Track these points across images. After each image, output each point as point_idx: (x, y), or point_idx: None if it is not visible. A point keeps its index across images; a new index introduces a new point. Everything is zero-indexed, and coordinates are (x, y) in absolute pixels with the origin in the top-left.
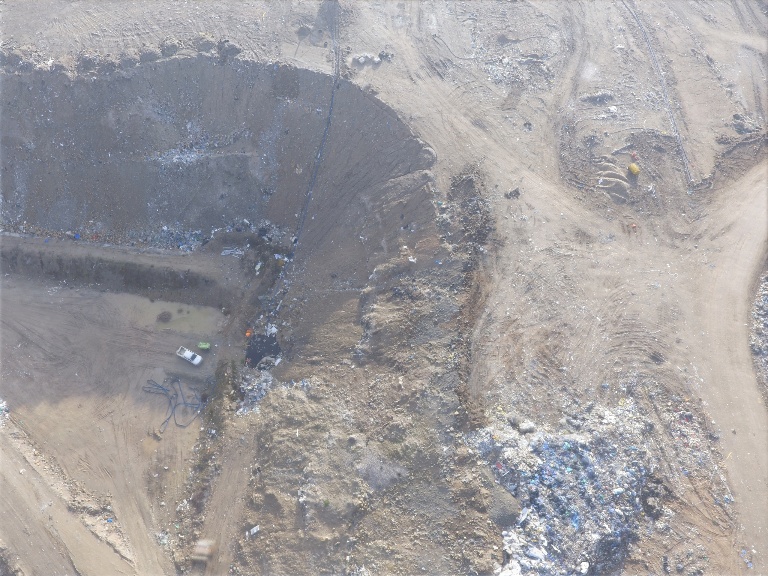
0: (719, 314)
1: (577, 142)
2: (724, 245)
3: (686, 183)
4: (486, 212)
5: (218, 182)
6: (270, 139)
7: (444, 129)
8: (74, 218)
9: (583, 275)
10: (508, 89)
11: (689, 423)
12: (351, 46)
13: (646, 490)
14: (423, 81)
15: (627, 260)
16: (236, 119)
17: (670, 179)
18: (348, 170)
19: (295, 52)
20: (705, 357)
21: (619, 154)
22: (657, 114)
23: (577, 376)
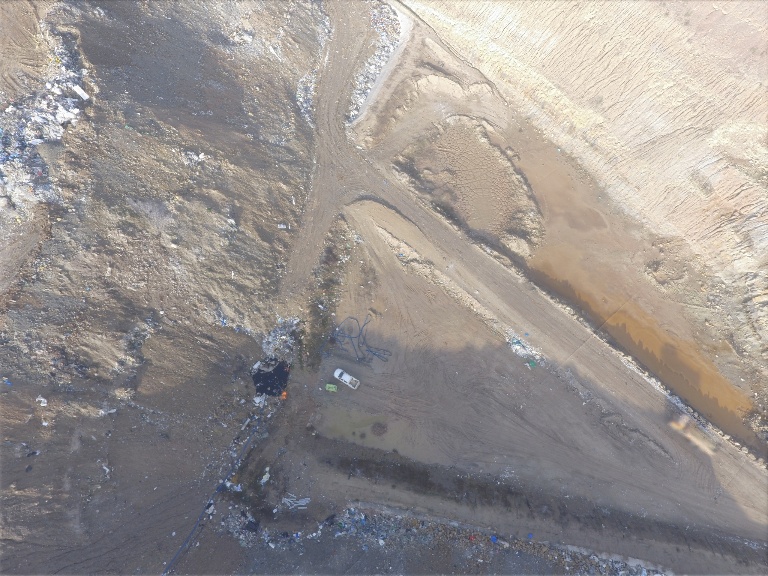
0: None
1: None
2: None
3: None
4: None
5: None
6: None
7: None
8: (503, 567)
9: None
10: None
11: None
12: None
13: None
14: None
15: None
16: None
17: None
18: None
19: None
20: None
21: None
22: None
23: None
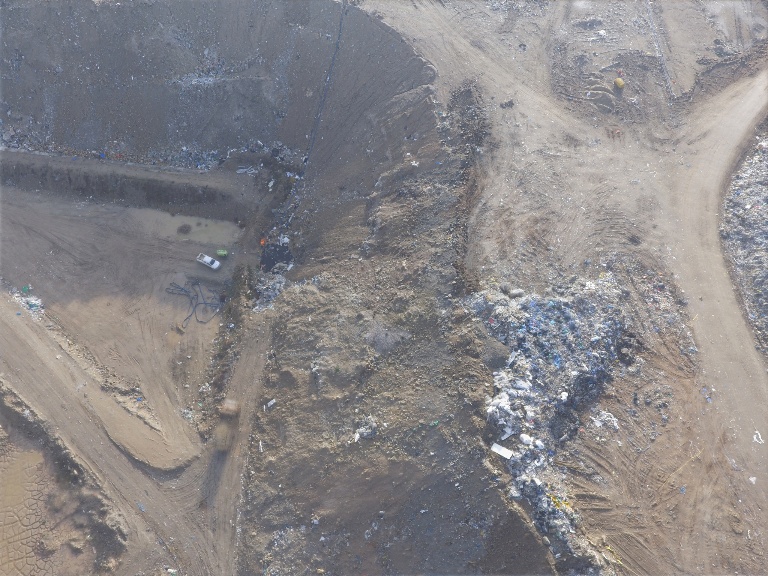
0: (692, 205)
1: (568, 61)
2: (700, 149)
3: (667, 96)
4: (483, 119)
5: (234, 104)
6: (282, 64)
7: (445, 49)
8: (99, 138)
9: (570, 172)
10: (505, 15)
11: (661, 292)
12: None
13: (620, 341)
14: (426, 8)
15: (611, 160)
16: (250, 45)
17: (653, 93)
18: (355, 91)
19: None
20: (678, 240)
21: (606, 71)
22: (643, 37)
23: (563, 254)
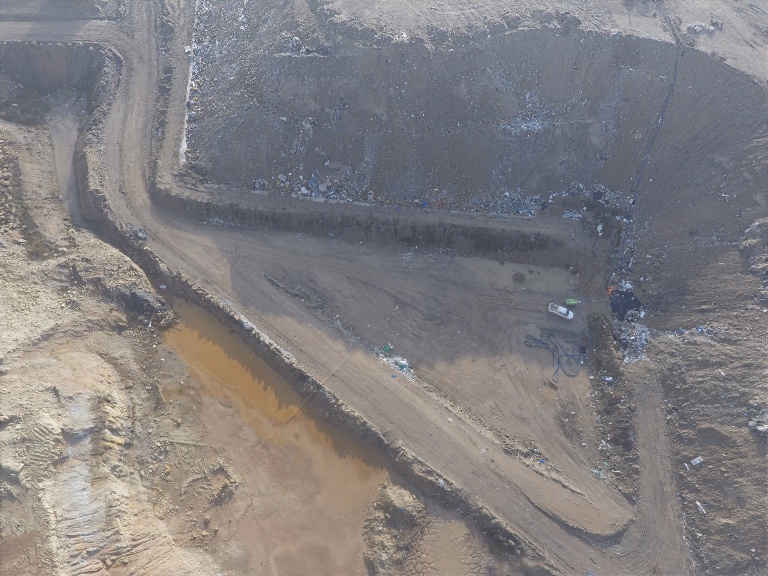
0: None
1: None
2: None
3: None
4: None
5: (560, 148)
6: (609, 106)
7: None
8: (420, 187)
9: None
10: None
11: None
12: (680, 16)
13: None
14: (762, 47)
15: None
16: (574, 88)
17: None
18: (694, 133)
19: (629, 22)
20: None
21: None
22: None
23: None
